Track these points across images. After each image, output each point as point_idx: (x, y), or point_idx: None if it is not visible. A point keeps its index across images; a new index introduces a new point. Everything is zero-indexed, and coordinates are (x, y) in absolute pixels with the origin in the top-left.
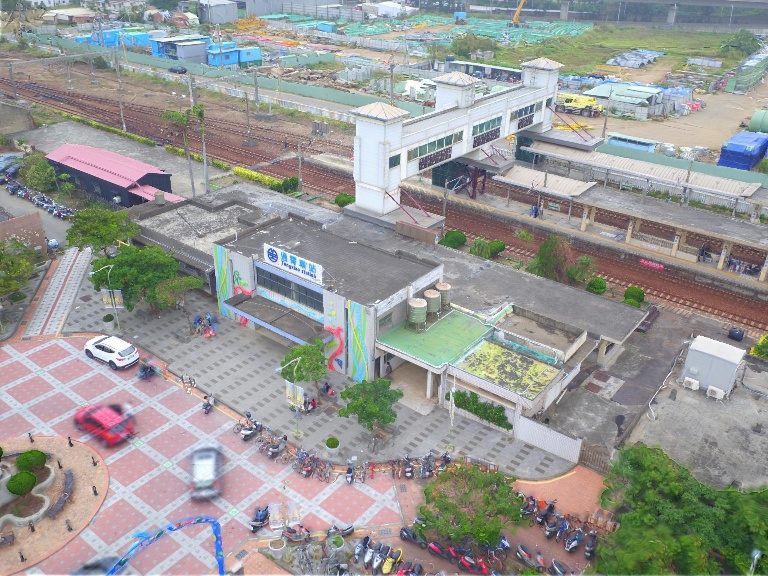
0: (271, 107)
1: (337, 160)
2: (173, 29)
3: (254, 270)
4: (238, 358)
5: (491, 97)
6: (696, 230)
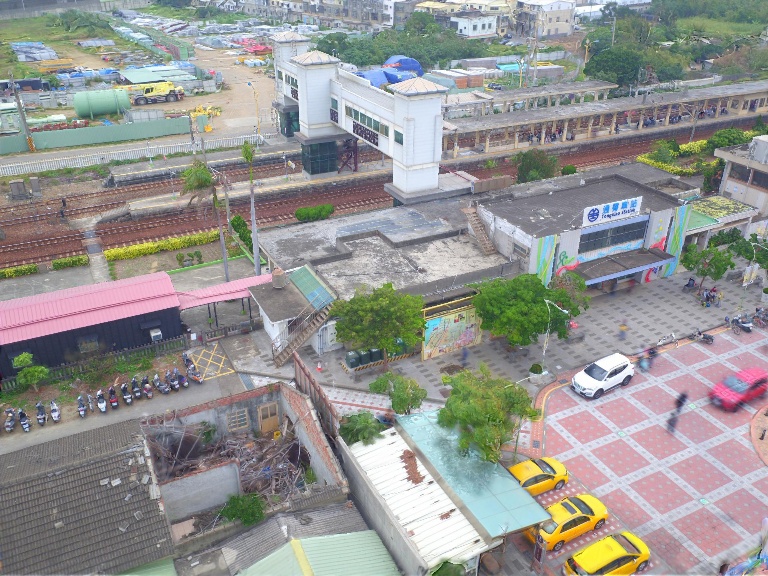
0: None
1: (166, 199)
2: None
3: None
4: (620, 317)
5: None
6: (537, 121)
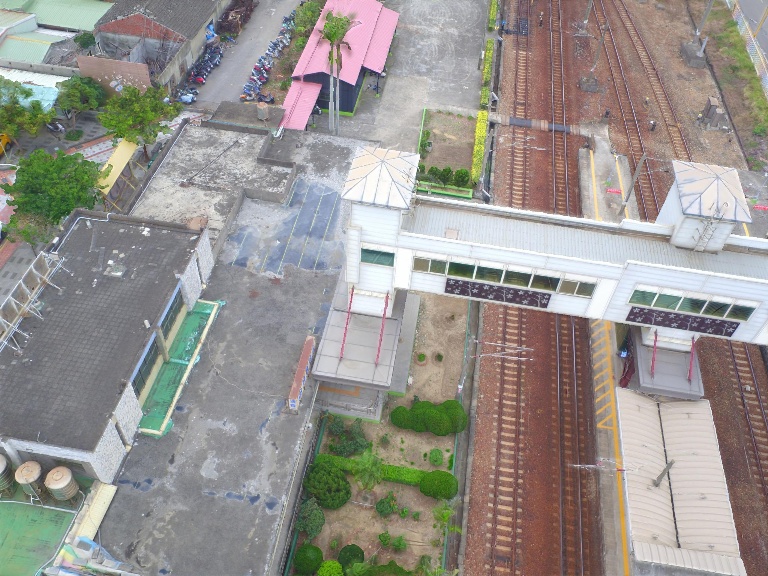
0: (732, 42)
1: None
2: None
3: None
4: None
5: None
6: None
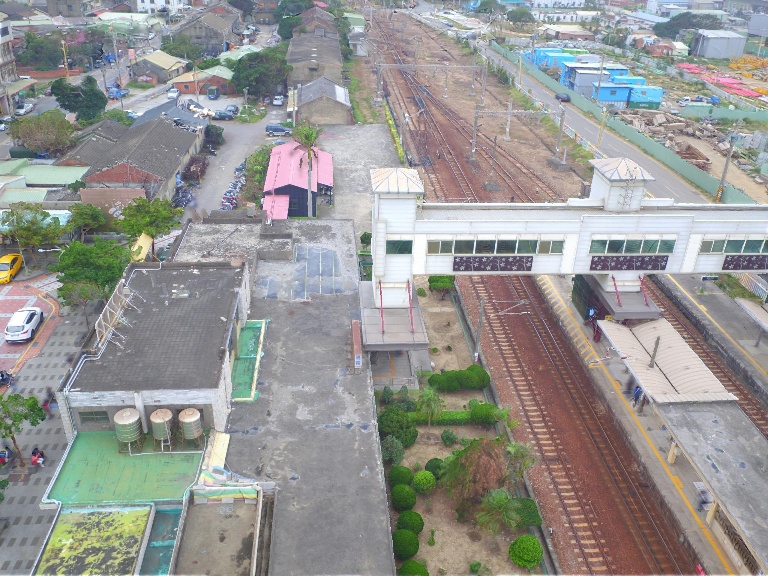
0: (583, 155)
1: None
2: (635, 56)
3: None
4: None
5: (695, 209)
6: None
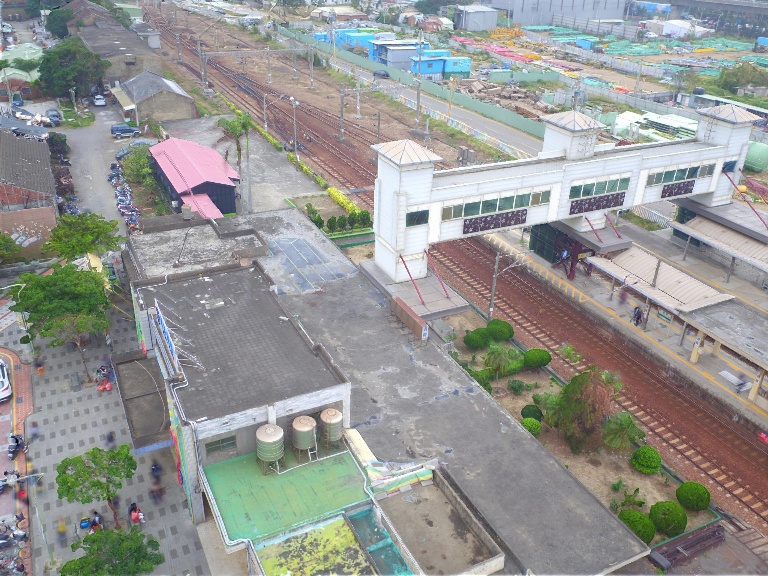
0: (437, 124)
1: None
2: (416, 33)
3: (150, 327)
4: (101, 428)
5: (630, 149)
6: None
